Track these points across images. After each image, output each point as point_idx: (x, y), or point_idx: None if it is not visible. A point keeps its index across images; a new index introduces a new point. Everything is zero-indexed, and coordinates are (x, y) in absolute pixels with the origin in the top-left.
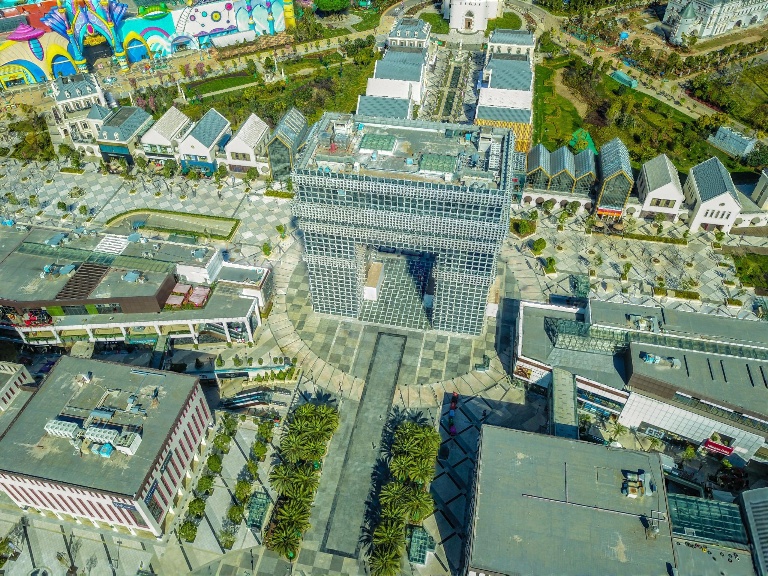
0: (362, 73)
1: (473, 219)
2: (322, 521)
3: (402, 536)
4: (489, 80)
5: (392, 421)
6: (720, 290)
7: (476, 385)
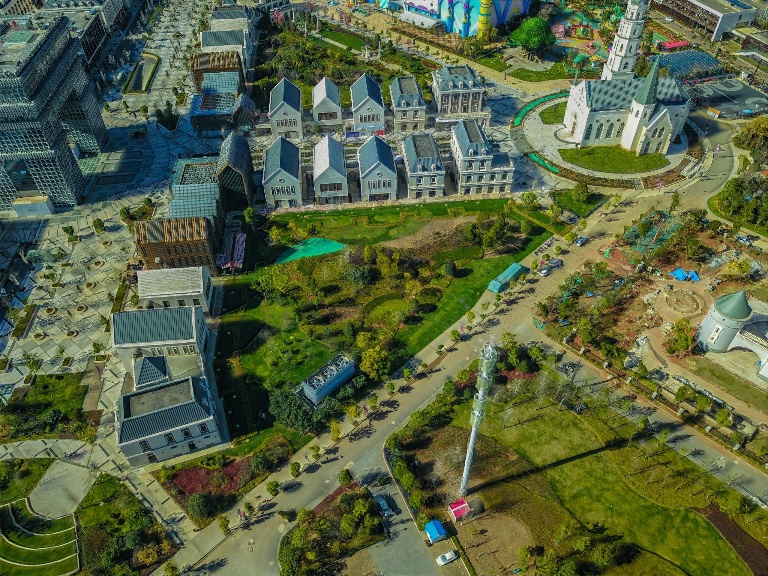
0: None
1: None
2: None
3: None
4: (365, 143)
5: None
6: None
7: None
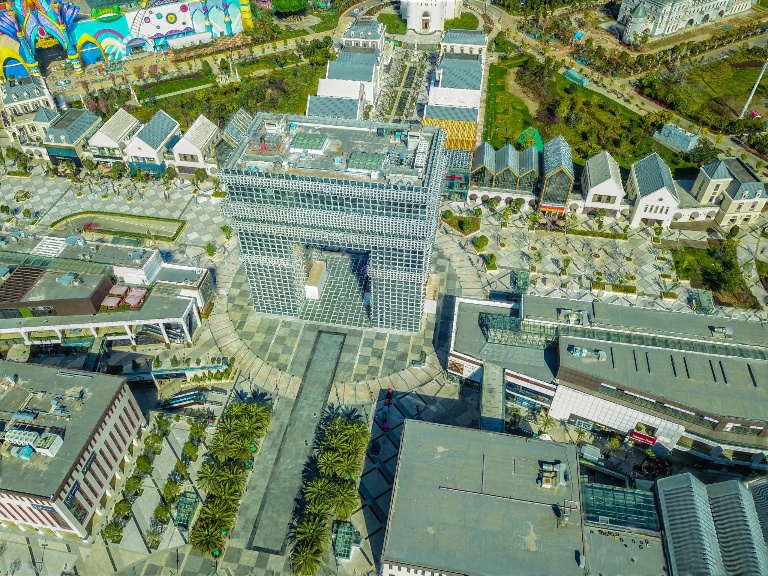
0: (317, 74)
1: (400, 216)
2: (250, 519)
3: (325, 531)
4: (440, 80)
5: (326, 418)
6: (657, 284)
7: (412, 381)
